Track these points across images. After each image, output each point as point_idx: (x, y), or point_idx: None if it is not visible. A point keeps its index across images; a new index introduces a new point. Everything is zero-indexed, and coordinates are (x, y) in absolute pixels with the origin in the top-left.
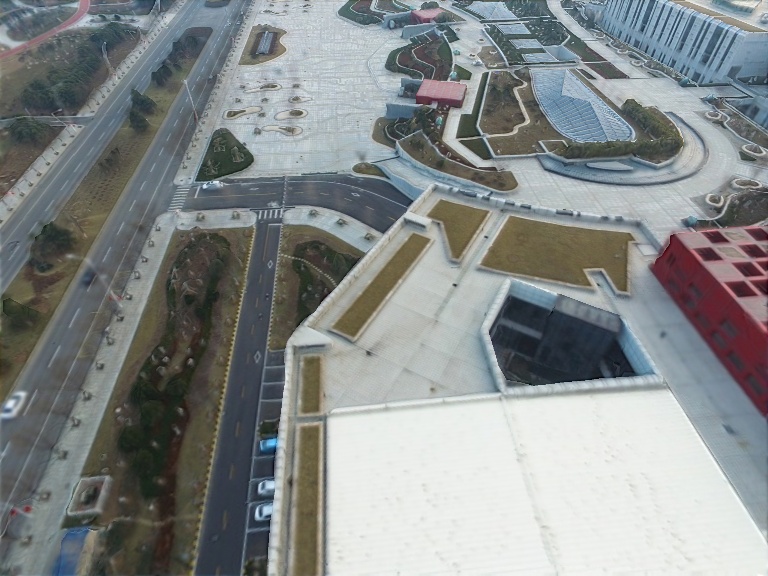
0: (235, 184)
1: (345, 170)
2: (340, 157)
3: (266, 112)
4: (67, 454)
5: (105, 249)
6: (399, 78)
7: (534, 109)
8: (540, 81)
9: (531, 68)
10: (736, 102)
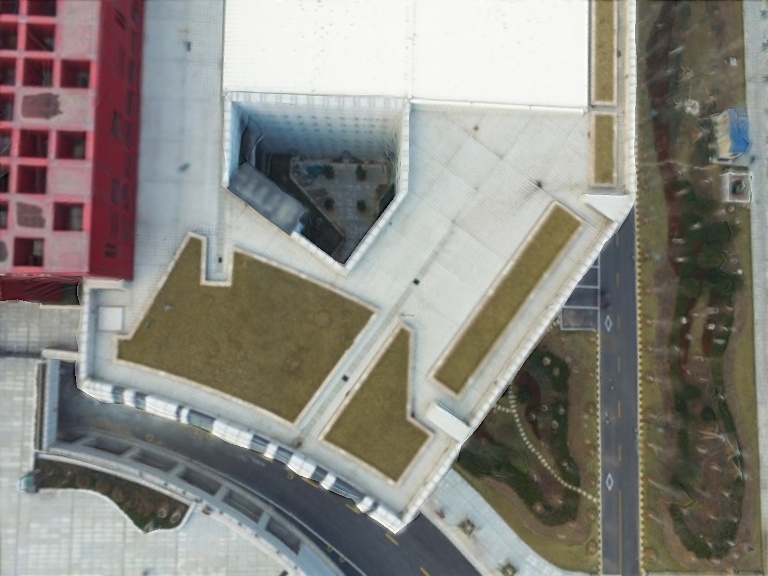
0: None
1: None
2: None
3: None
4: None
5: None
6: None
7: None
8: None
9: None
10: None
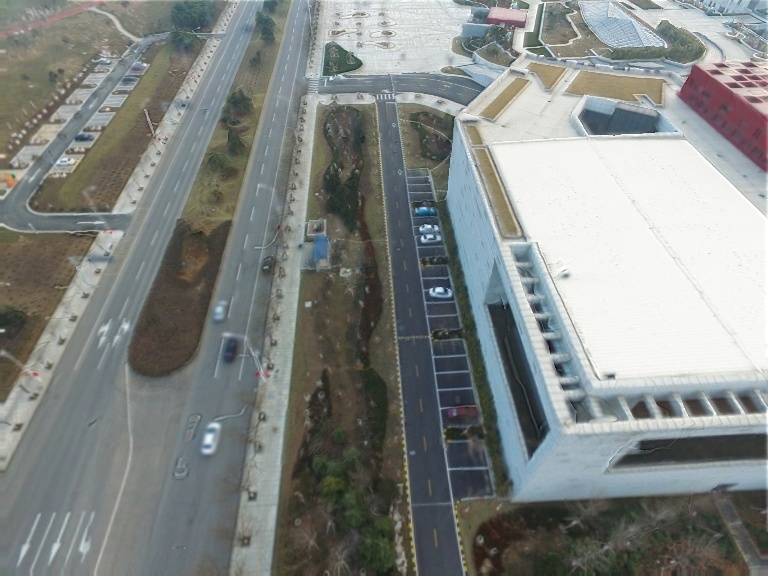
0: (352, 79)
1: (435, 71)
2: (429, 63)
3: (362, 32)
4: (293, 213)
5: (271, 114)
6: (466, 9)
7: (584, 28)
8: (588, 10)
9: (579, 1)
10: (753, 27)
